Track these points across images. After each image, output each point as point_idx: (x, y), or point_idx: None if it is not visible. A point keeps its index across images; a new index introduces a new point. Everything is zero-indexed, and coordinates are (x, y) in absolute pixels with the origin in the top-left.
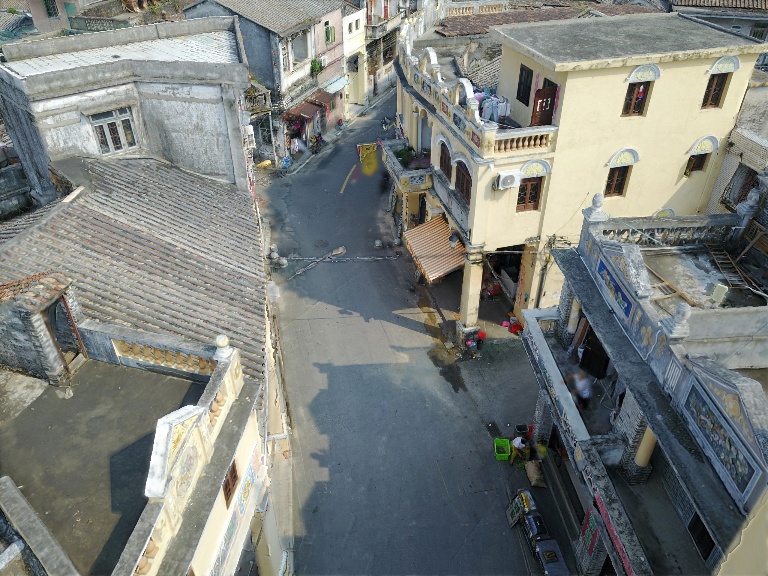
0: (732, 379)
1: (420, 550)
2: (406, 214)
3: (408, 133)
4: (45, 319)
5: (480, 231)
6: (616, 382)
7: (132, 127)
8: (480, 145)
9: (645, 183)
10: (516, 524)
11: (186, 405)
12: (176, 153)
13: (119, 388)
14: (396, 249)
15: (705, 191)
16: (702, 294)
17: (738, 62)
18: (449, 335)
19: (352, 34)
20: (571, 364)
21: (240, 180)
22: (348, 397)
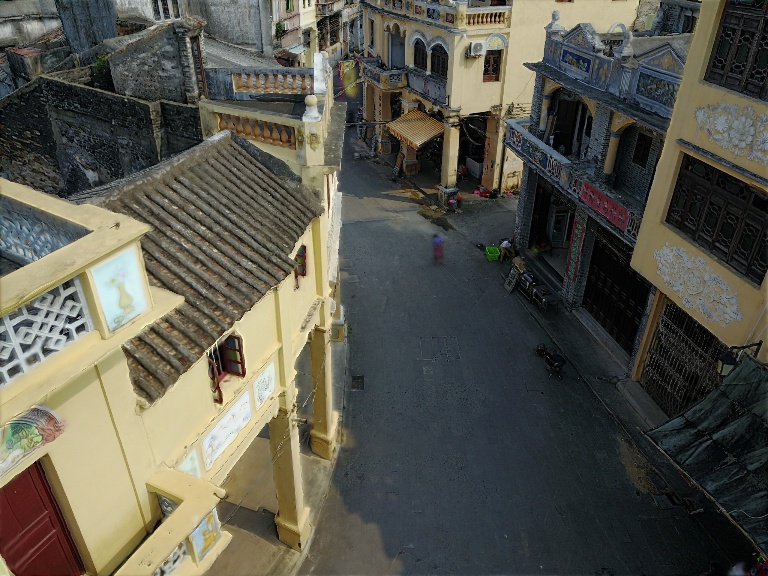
0: None
1: (443, 308)
2: (380, 128)
3: (380, 51)
4: (191, 46)
5: (457, 96)
6: (581, 145)
7: (178, 1)
8: (455, 19)
9: None
10: (514, 289)
11: (297, 109)
12: (213, 25)
13: None
14: (373, 159)
15: None
16: None
17: None
18: (432, 202)
19: (306, 9)
20: None
21: (267, 48)
22: (360, 239)
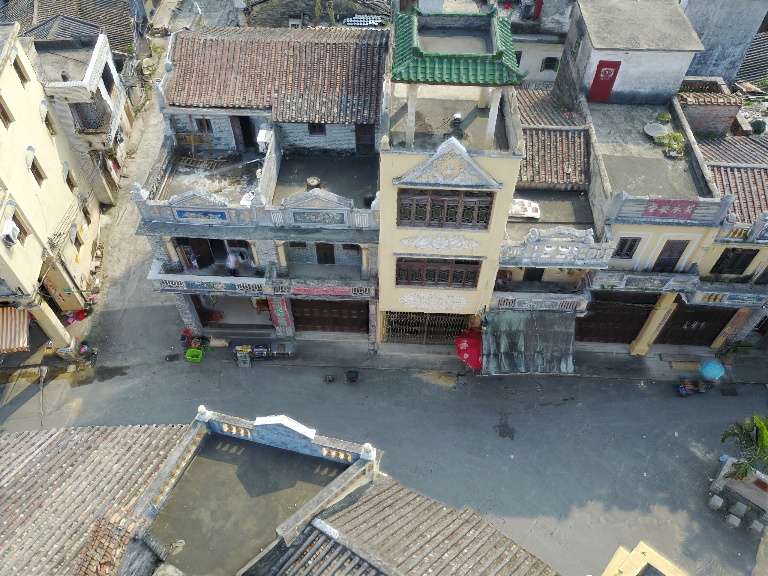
0: (311, 195)
1: None
2: None
3: None
4: None
5: (25, 281)
6: None
7: None
8: None
9: (46, 160)
10: (251, 363)
11: (218, 457)
12: None
13: (185, 507)
14: None
15: (63, 135)
16: (213, 183)
17: (15, 46)
18: (59, 366)
19: None
20: (195, 273)
21: None
22: None
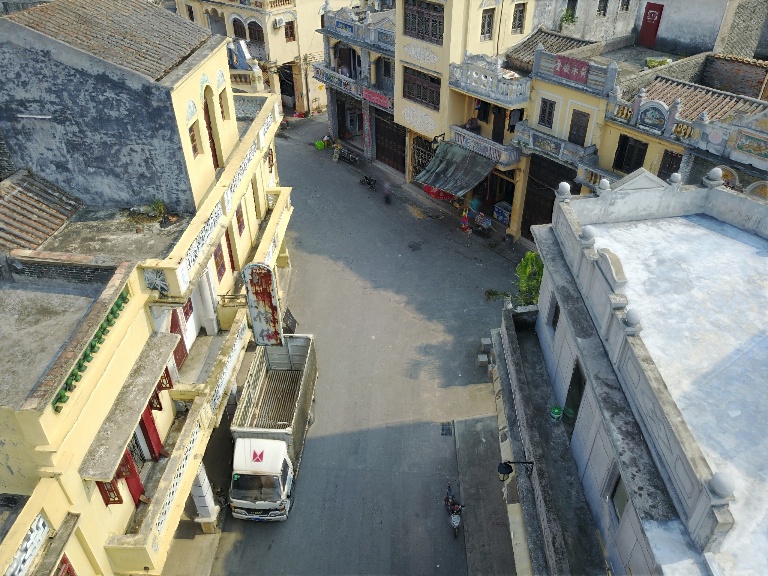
0: None
1: (305, 176)
2: None
3: None
4: None
5: (273, 53)
6: (357, 72)
7: None
8: (263, 5)
9: None
10: (338, 159)
11: None
12: None
13: None
14: None
15: None
16: None
17: None
18: None
19: None
20: None
21: None
22: None
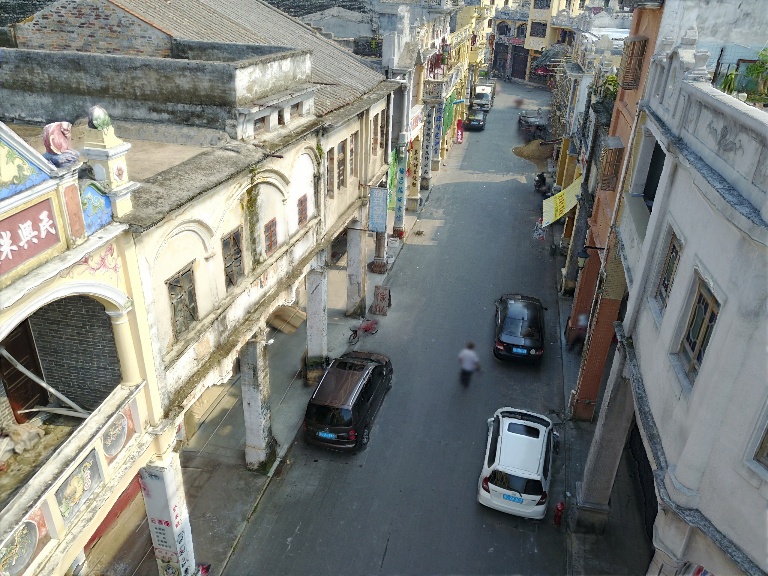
0: None
1: None
2: None
3: None
4: None
5: None
6: None
7: None
8: None
9: None
10: None
11: None
12: None
13: None
14: None
15: None
16: None
17: None
18: None
19: None
20: None
21: None
22: None
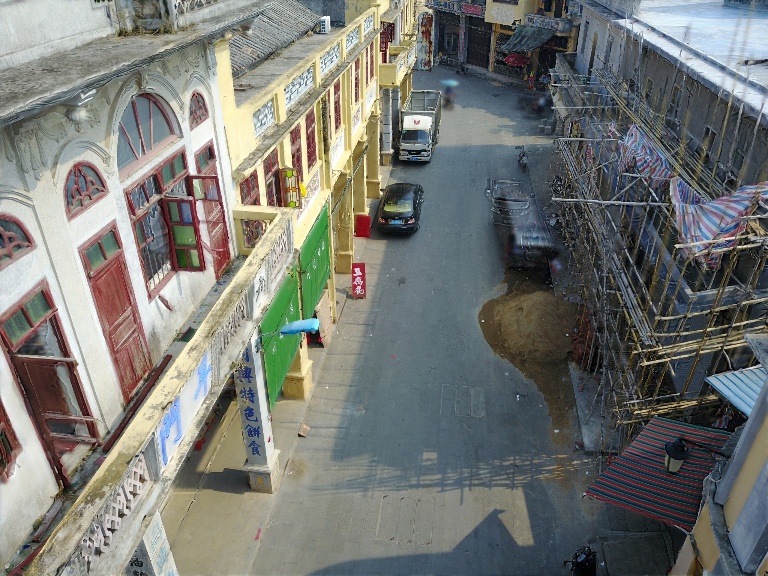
0: None
1: None
2: None
3: None
4: None
5: None
6: None
7: None
8: None
9: None
10: (439, 64)
11: None
12: None
13: None
14: None
15: None
16: None
17: None
18: None
19: None
20: None
21: None
22: None
